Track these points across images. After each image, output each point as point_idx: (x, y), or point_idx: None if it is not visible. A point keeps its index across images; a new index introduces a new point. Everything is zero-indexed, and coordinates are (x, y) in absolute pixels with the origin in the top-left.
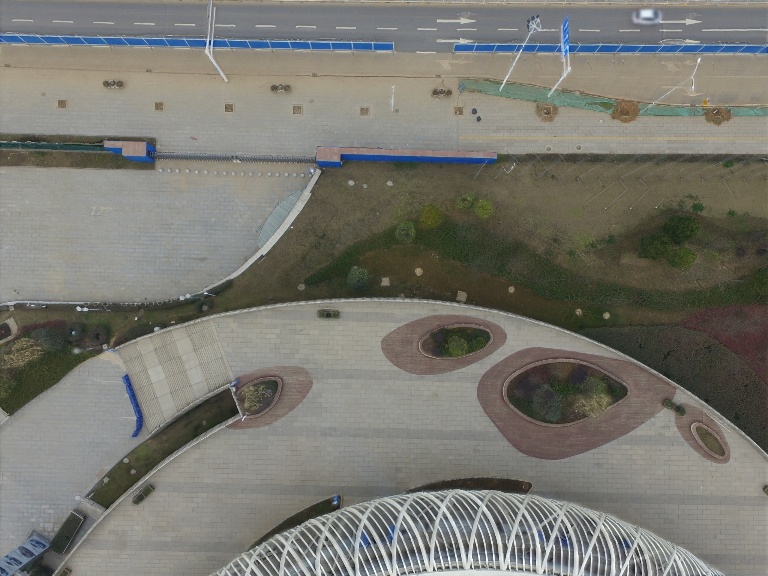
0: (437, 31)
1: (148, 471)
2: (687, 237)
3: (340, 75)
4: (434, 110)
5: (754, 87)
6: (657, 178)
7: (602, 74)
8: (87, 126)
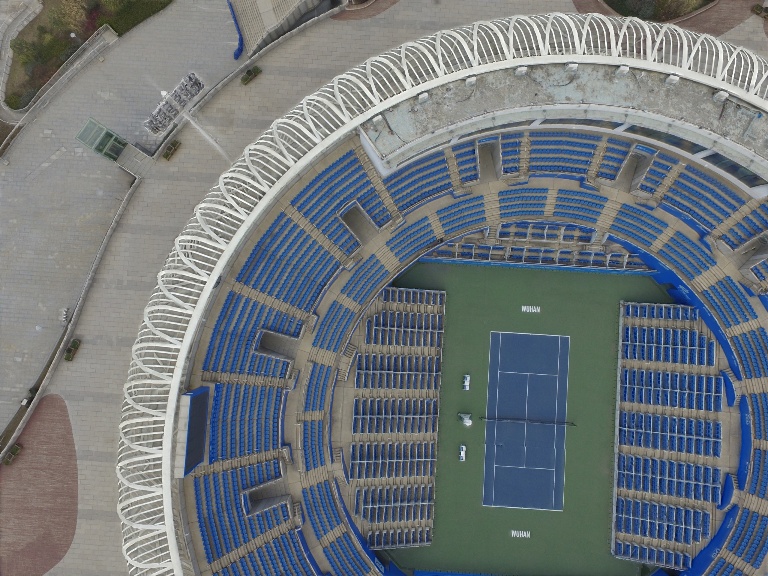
0: None
1: None
2: None
3: None
4: None
5: None
6: None
7: None
8: None
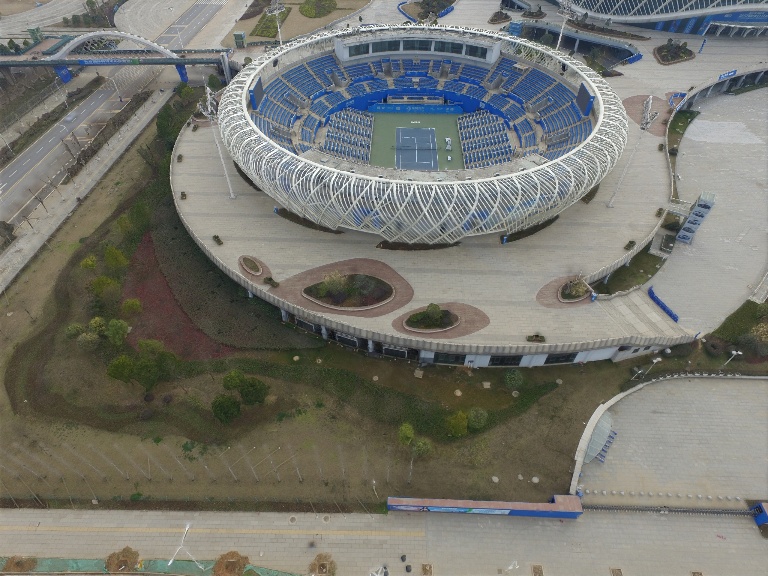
0: None
1: (631, 271)
2: None
3: None
4: (456, 572)
5: None
6: (218, 481)
7: None
8: None
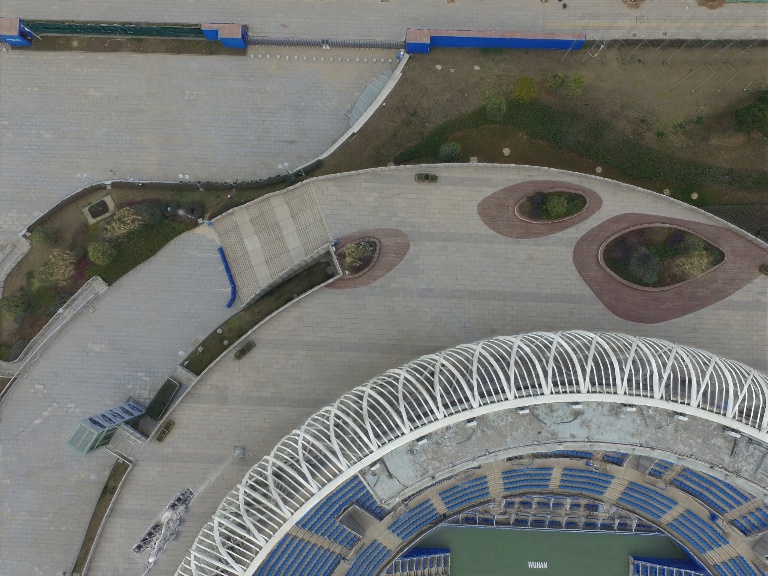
0: None
1: None
2: None
3: None
4: None
5: None
6: (745, 62)
7: None
8: (181, 14)
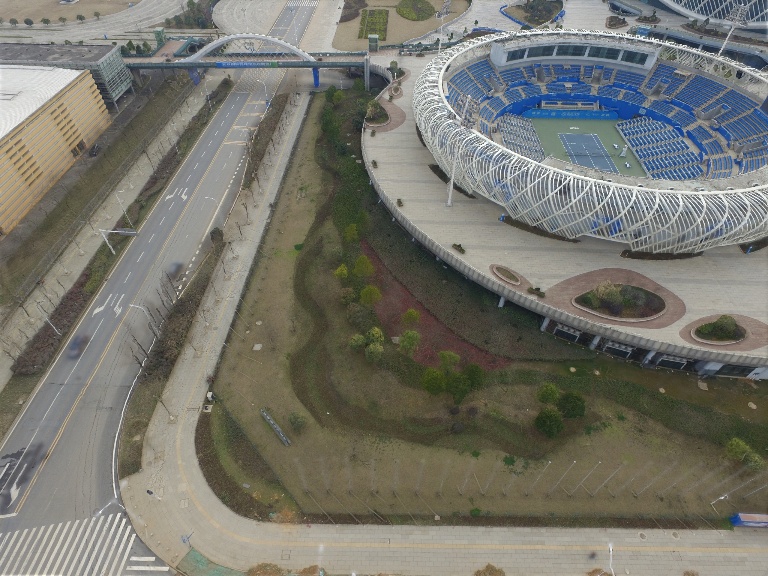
0: None
1: None
2: None
3: None
4: None
5: None
6: (552, 496)
7: None
8: None
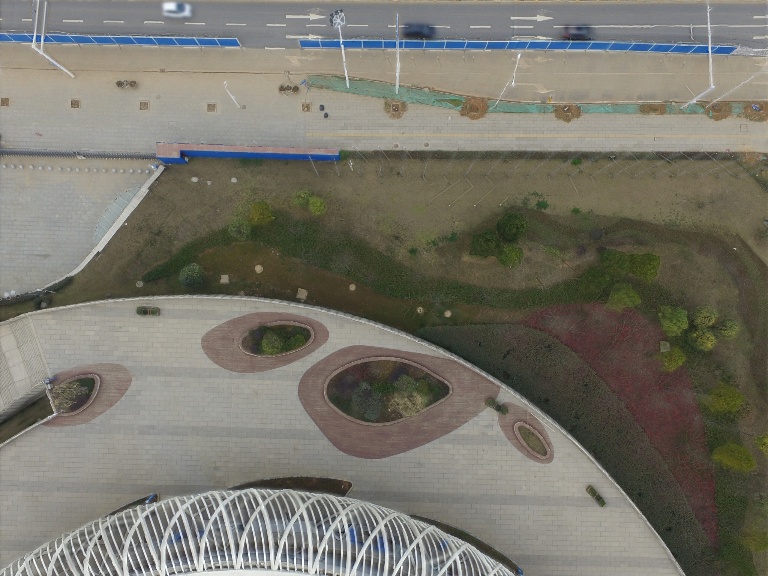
0: (286, 27)
1: None
2: (515, 234)
3: (188, 71)
4: (281, 106)
5: (605, 84)
6: (503, 175)
7: (452, 71)
8: None
